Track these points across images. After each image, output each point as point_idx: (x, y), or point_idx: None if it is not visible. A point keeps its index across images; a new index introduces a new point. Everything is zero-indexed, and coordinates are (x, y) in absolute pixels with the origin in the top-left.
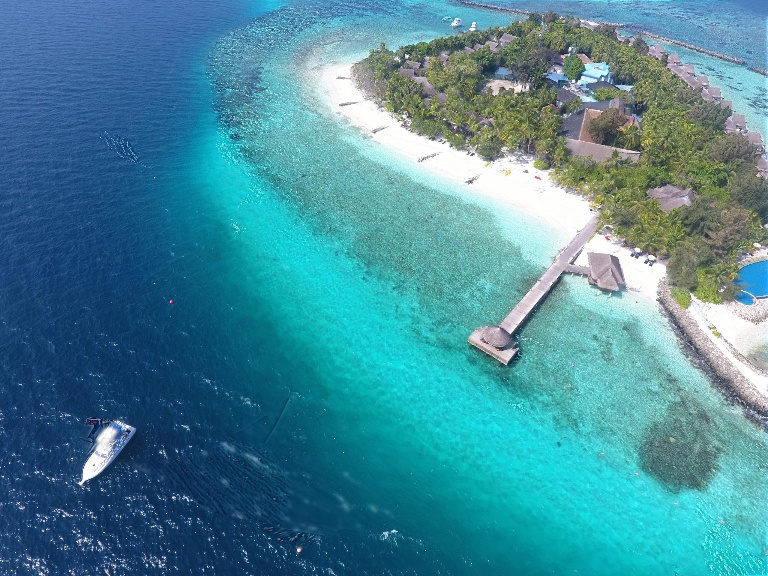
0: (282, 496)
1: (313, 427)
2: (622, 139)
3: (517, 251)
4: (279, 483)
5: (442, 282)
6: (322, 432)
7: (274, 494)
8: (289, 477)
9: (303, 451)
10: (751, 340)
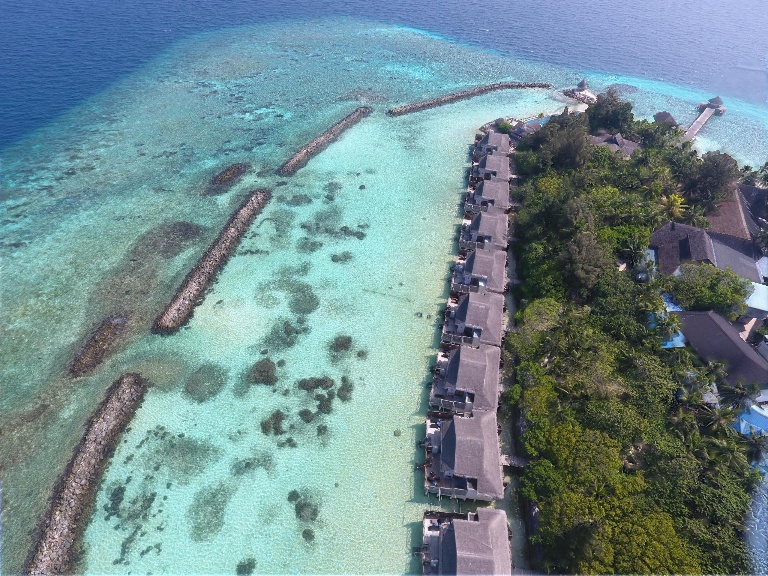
0: (763, 63)
1: (767, 91)
2: (689, 173)
3: (723, 145)
4: (767, 67)
5: (759, 134)
6: (762, 92)
7: (766, 62)
8: (764, 71)
9: (765, 81)
10: (577, 107)
